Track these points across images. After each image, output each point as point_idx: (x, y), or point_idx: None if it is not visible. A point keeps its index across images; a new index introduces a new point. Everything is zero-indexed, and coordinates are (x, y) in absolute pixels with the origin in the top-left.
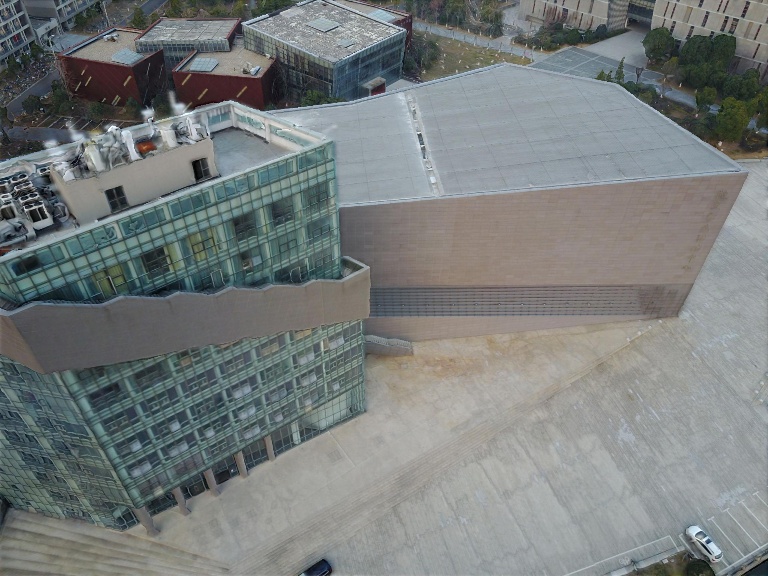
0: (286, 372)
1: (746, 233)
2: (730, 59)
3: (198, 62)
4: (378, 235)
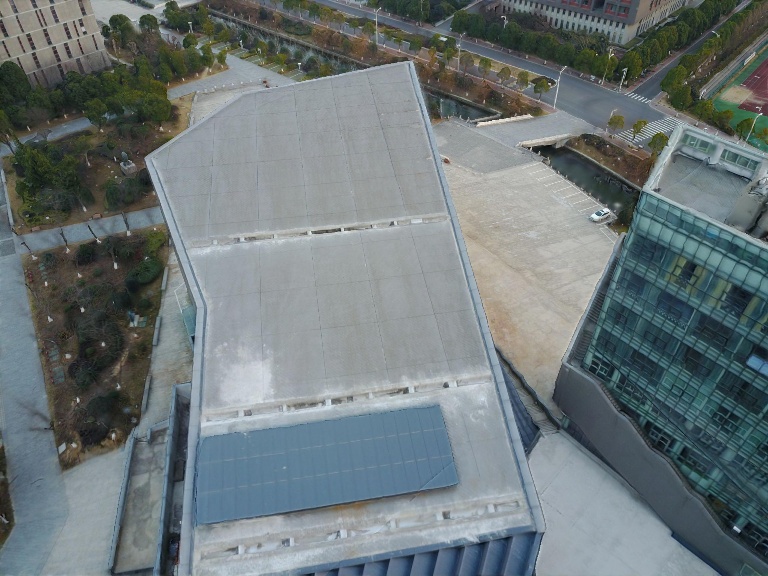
0: None
1: None
2: (28, 81)
3: None
4: None
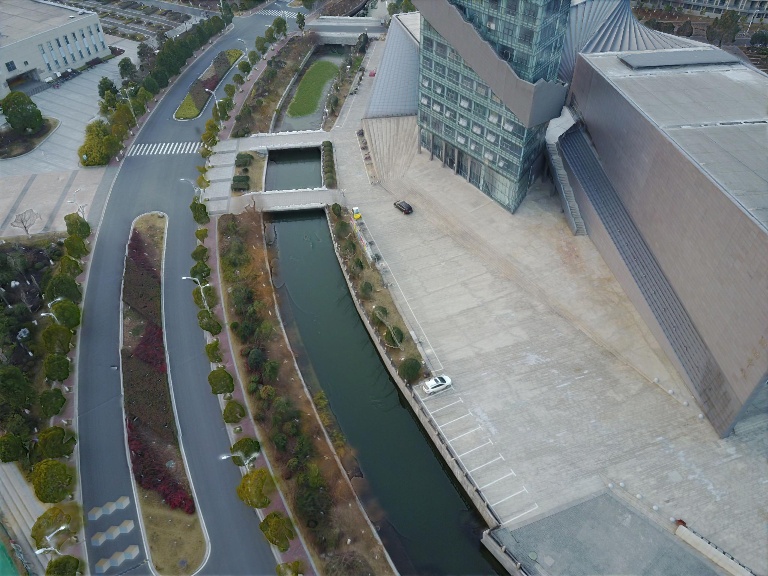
0: (484, 118)
1: None
2: None
3: None
4: (627, 136)
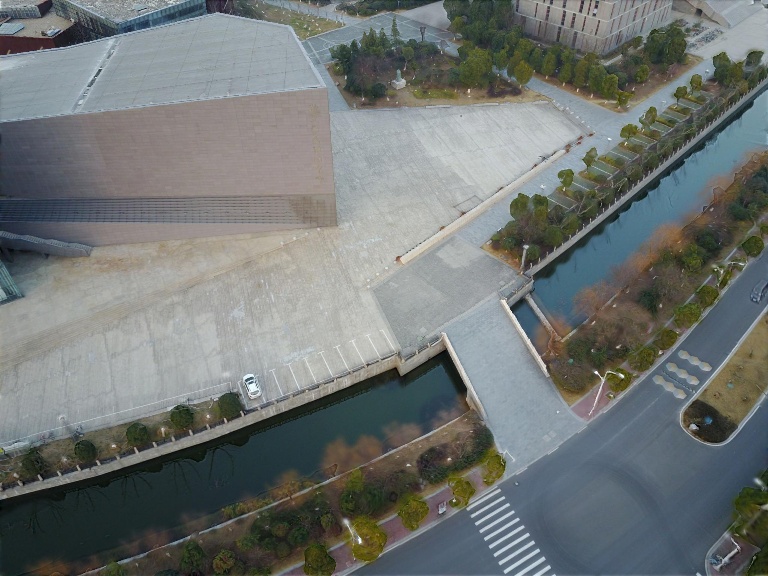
0: None
1: (444, 162)
2: (507, 17)
3: (4, 26)
4: (35, 149)
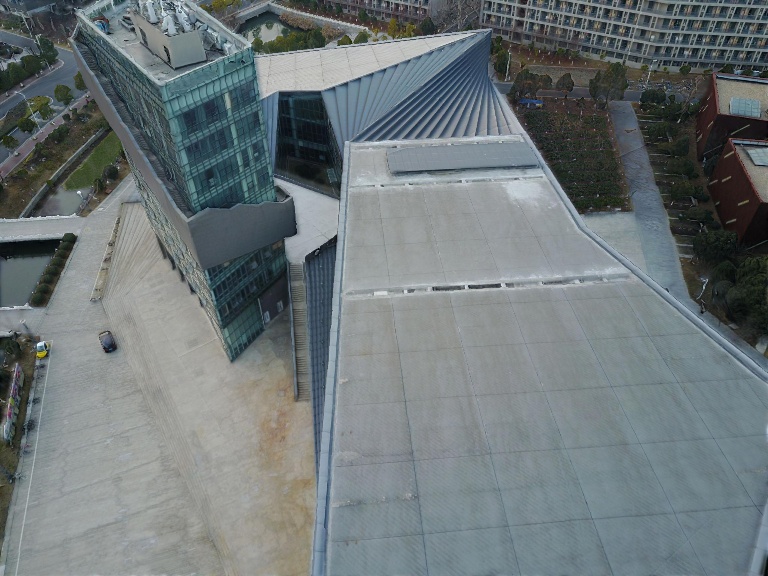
0: None
1: None
2: None
3: None
4: None
